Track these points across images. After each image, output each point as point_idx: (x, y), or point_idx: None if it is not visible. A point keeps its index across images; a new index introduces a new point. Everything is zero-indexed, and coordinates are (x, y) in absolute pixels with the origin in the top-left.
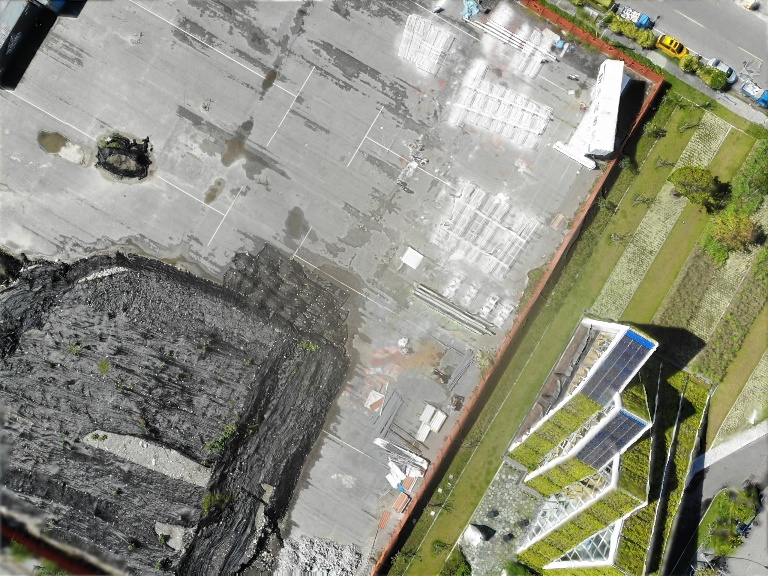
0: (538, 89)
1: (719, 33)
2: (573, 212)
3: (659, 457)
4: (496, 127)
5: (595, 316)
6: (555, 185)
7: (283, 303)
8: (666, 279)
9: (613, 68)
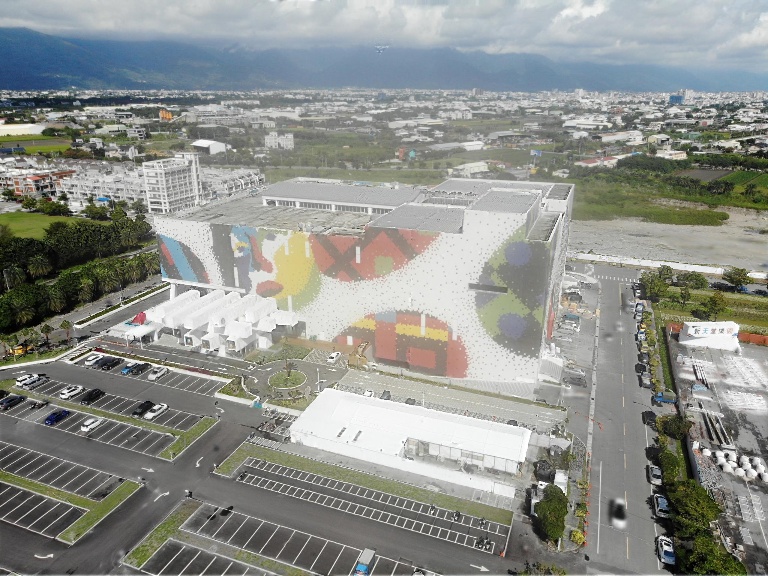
0: (716, 362)
1: (620, 319)
2: (767, 347)
3: None
4: (759, 371)
5: None
6: (761, 353)
7: None
8: (760, 322)
9: (692, 324)
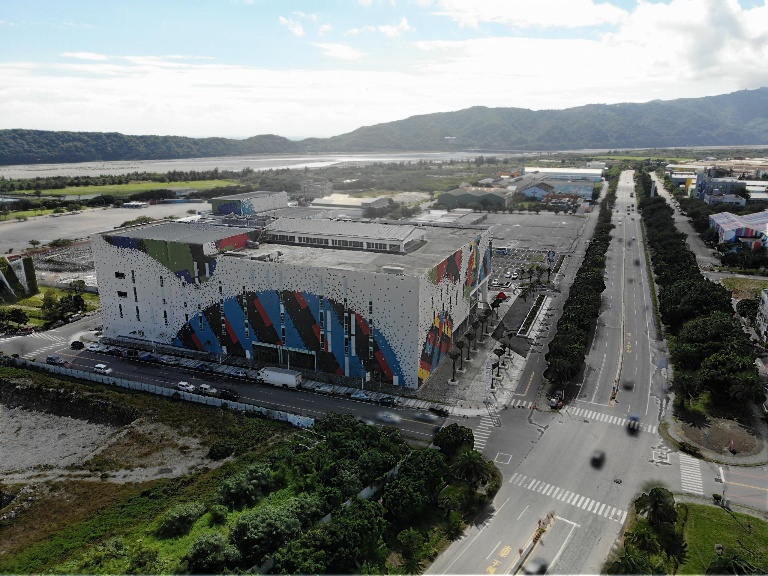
0: None
1: None
2: None
3: None
4: None
5: (39, 293)
6: None
7: (90, 264)
8: None
9: None
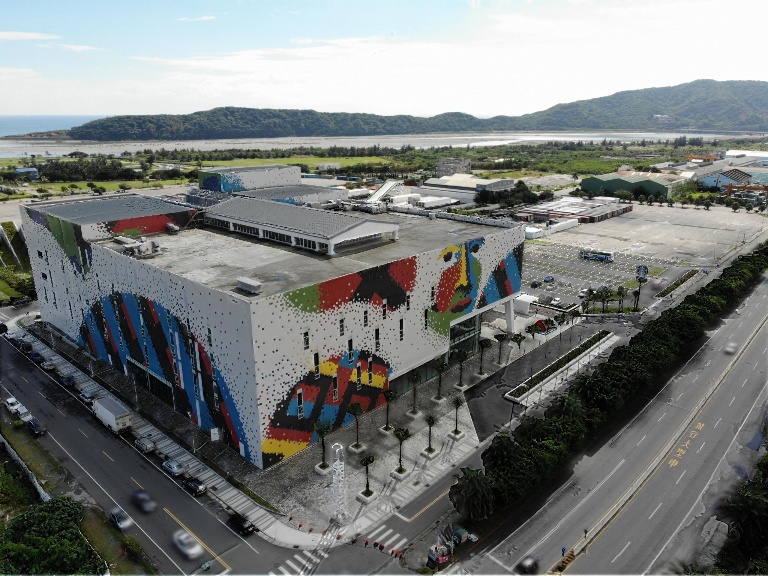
0: None
1: None
2: None
3: (0, 246)
4: None
5: None
6: None
7: None
8: None
9: None
